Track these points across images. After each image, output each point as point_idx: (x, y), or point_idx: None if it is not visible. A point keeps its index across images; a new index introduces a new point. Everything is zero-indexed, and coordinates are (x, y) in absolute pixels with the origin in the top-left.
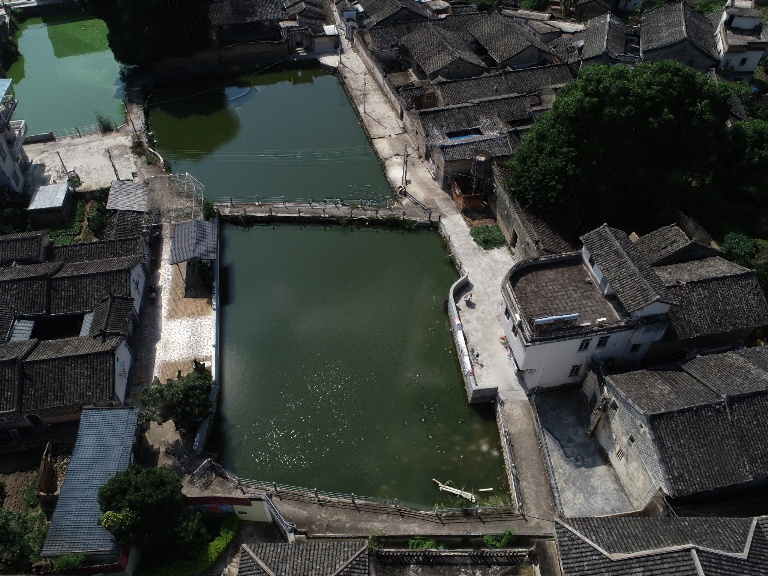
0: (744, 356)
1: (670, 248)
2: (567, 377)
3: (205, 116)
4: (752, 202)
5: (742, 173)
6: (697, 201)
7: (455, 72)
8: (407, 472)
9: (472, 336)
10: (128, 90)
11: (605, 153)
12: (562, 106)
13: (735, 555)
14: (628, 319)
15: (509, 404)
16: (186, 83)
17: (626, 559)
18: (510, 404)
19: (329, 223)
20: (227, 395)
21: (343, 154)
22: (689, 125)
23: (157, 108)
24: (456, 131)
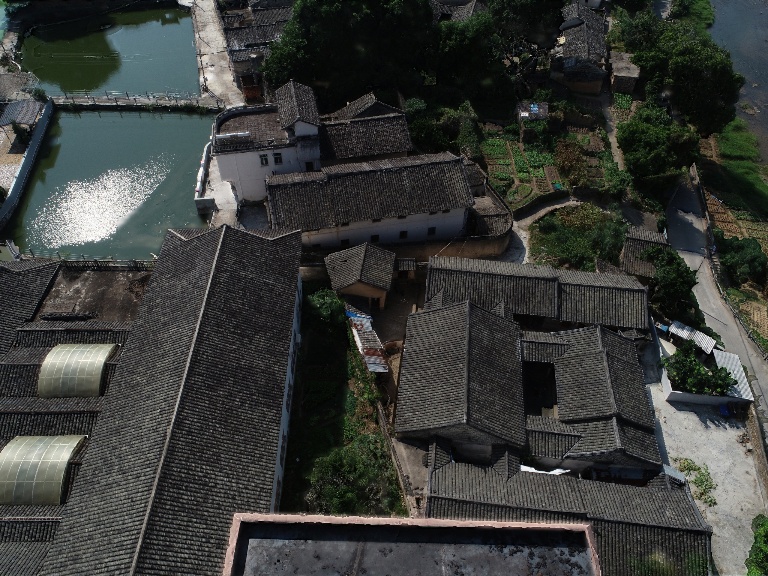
0: (368, 163)
1: (362, 108)
2: (265, 192)
3: (69, 41)
4: (456, 86)
5: (440, 60)
6: (408, 83)
7: (274, 4)
8: (134, 250)
9: (214, 174)
10: (10, 23)
11: (326, 42)
12: (296, 7)
13: (262, 237)
14: (289, 138)
15: (223, 211)
16: (63, 19)
17: (192, 239)
18: (223, 211)
19: (140, 110)
20: (22, 210)
21: (150, 55)
22: (384, 19)
23: (31, 36)
24: (253, 43)
